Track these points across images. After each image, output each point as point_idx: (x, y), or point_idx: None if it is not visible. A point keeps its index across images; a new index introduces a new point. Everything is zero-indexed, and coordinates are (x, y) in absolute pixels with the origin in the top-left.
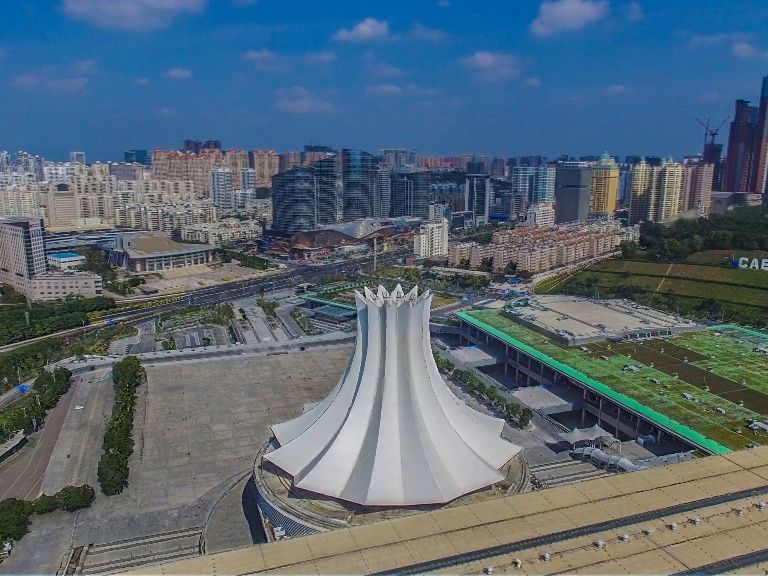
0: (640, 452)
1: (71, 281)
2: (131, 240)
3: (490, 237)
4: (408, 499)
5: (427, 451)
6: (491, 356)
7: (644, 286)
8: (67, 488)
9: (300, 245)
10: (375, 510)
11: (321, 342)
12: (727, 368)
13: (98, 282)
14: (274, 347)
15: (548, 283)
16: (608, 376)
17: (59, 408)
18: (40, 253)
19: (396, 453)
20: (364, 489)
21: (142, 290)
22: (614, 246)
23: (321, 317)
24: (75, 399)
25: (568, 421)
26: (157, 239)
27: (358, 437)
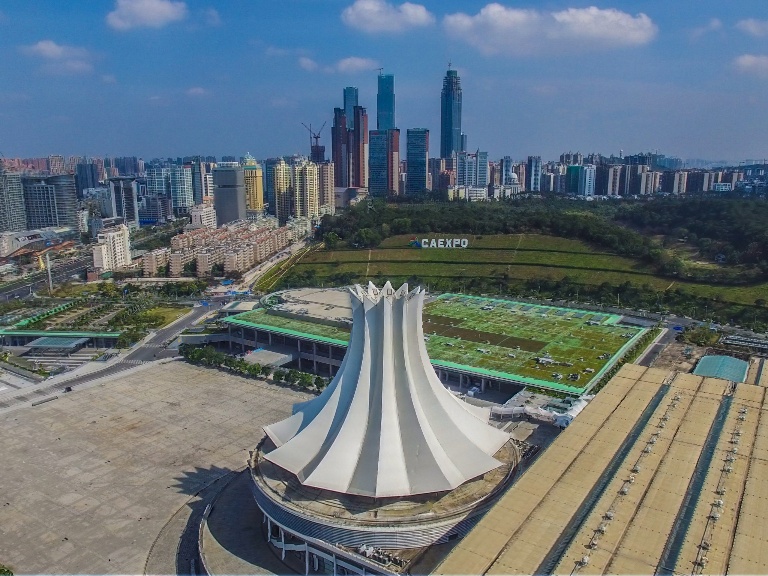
0: (477, 402)
1: None
2: None
3: (161, 242)
4: (467, 474)
5: None
6: (284, 354)
7: (357, 272)
8: None
9: None
10: (443, 494)
11: (81, 378)
12: (483, 325)
13: None
14: (23, 396)
15: (267, 280)
16: None
17: None
18: None
19: (433, 438)
20: (438, 477)
21: None
22: (288, 240)
23: (41, 352)
24: None
25: None
26: None
27: (395, 434)
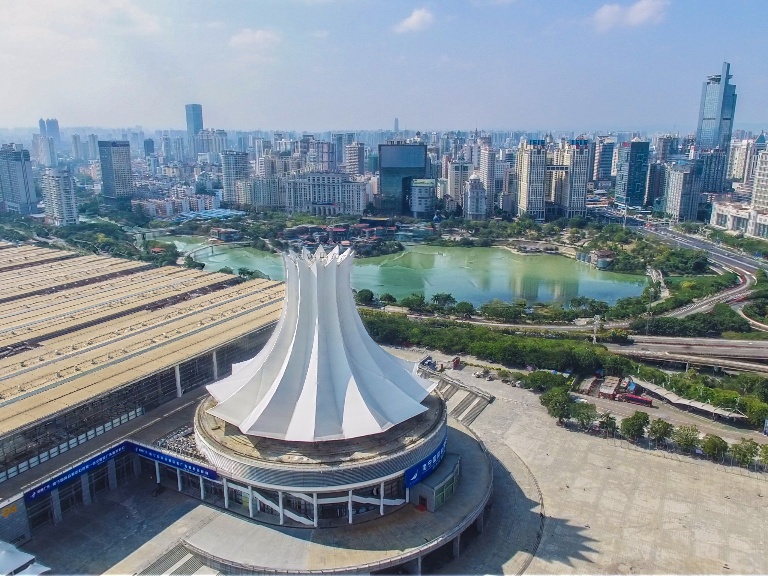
0: None
1: None
2: None
3: None
4: None
5: None
6: None
7: None
8: (564, 396)
9: None
10: None
11: None
12: None
13: None
14: None
15: None
16: None
17: None
18: None
19: None
20: None
21: None
22: None
23: None
24: None
25: None
26: None
27: None
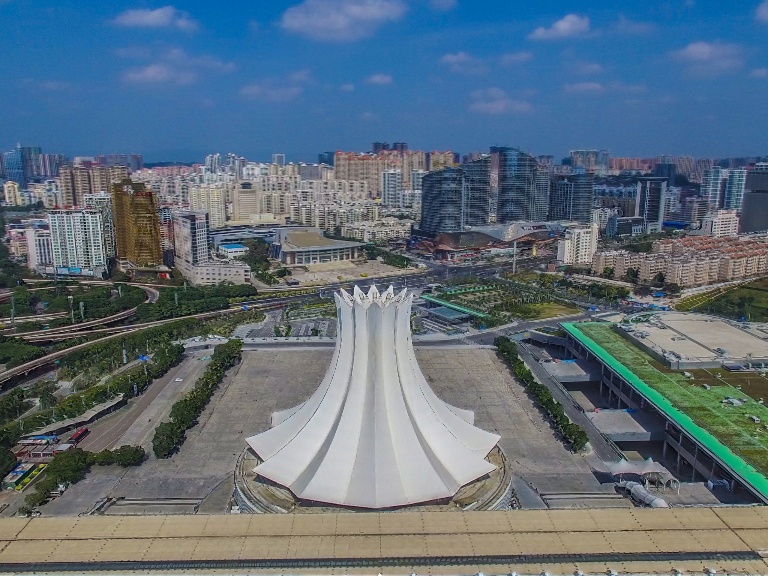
0: (704, 497)
1: (225, 269)
2: (287, 235)
3: None
4: (349, 499)
5: (380, 455)
6: (585, 372)
7: None
8: (124, 446)
9: (444, 246)
10: (318, 505)
11: (418, 342)
12: None
13: (247, 271)
14: None
15: (695, 299)
16: (698, 407)
17: (164, 379)
18: (204, 243)
19: (352, 453)
20: (306, 482)
21: (286, 281)
22: None
23: (434, 318)
24: (180, 372)
25: (649, 452)
26: (311, 235)
27: (323, 432)
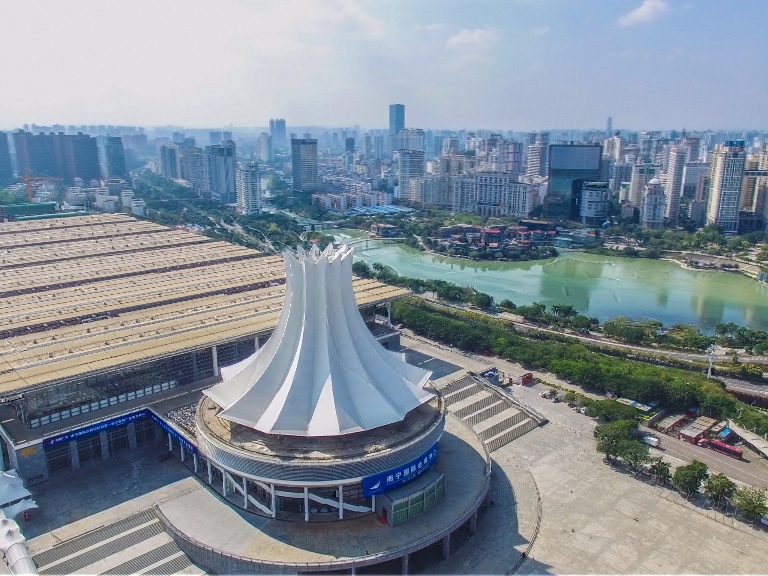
0: None
1: None
2: None
3: None
4: None
5: None
6: None
7: None
8: (622, 430)
9: None
10: None
11: None
12: None
13: None
14: None
15: None
16: None
17: None
18: None
19: None
20: None
21: None
22: None
23: None
24: None
25: None
26: None
27: None
